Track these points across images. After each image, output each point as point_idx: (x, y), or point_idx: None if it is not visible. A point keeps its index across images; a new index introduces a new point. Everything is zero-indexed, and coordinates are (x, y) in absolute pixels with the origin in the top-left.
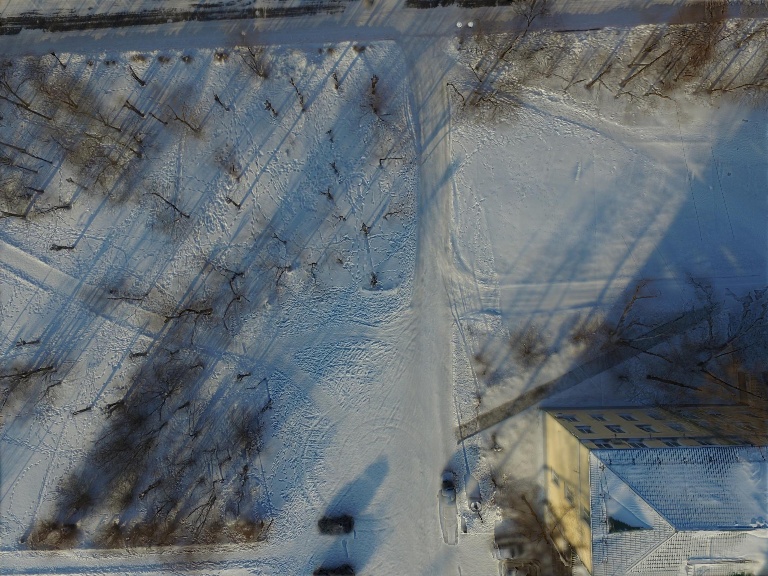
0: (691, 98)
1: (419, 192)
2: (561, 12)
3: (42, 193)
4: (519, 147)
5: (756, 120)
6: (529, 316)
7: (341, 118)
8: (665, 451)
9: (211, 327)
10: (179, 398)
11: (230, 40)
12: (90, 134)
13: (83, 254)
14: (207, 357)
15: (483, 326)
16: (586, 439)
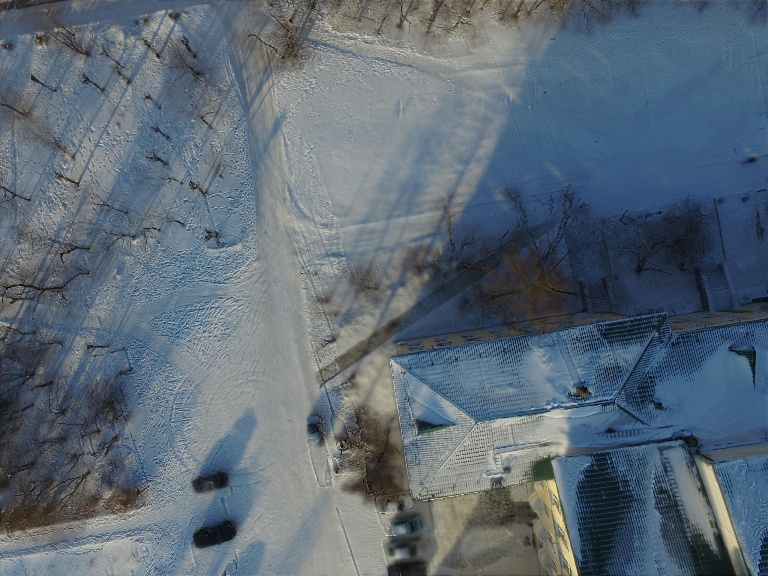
0: (499, 24)
1: (251, 148)
2: None
3: None
4: (341, 92)
5: (563, 37)
6: (373, 254)
7: (166, 85)
8: (461, 349)
9: (65, 305)
10: (42, 379)
11: (50, 23)
12: None
13: None
14: (64, 335)
15: (330, 269)
16: None
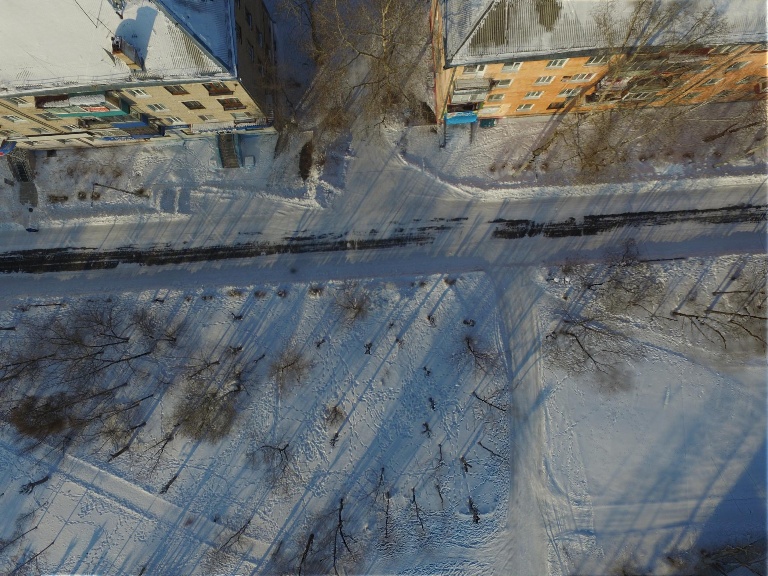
0: None
1: (512, 417)
2: (645, 240)
3: (144, 425)
4: (609, 373)
5: None
6: (622, 535)
7: (434, 347)
8: None
9: (313, 552)
10: None
11: (323, 272)
12: (189, 366)
13: (186, 483)
14: None
15: (578, 546)
16: None
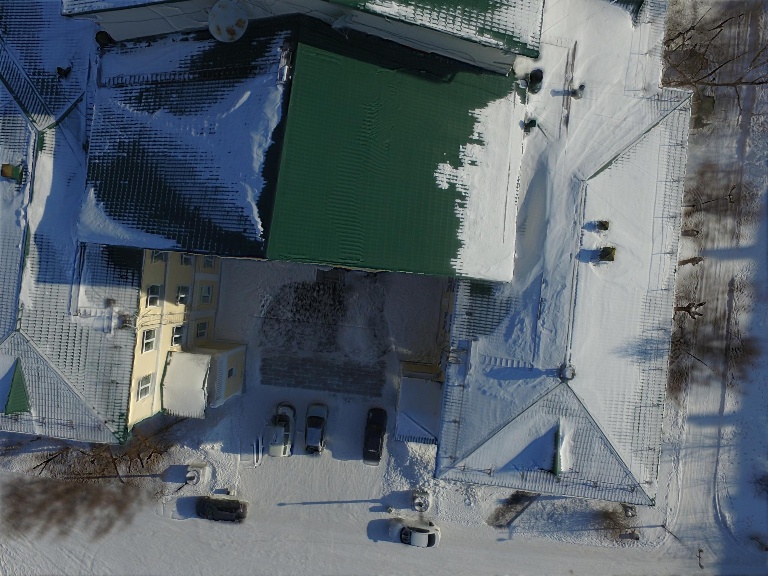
0: None
1: None
2: None
3: None
4: None
5: None
6: None
7: None
8: None
9: None
10: None
11: None
12: None
13: None
14: None
15: None
16: None
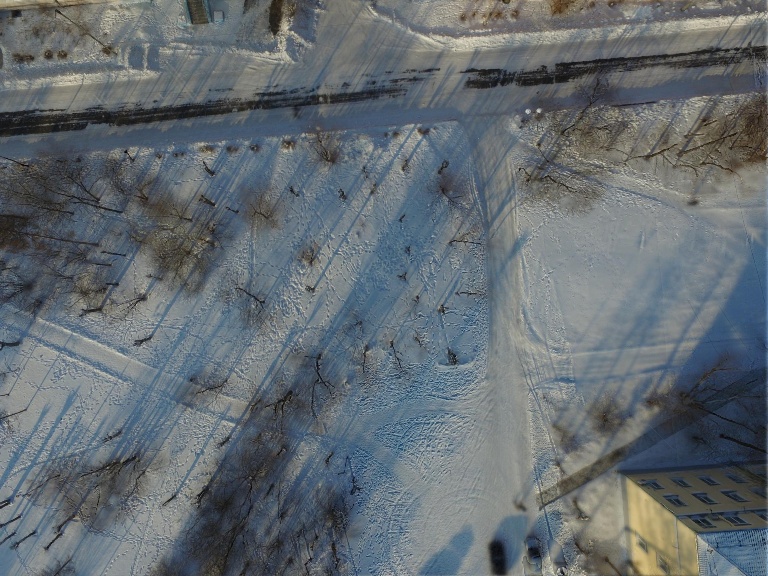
0: (746, 165)
1: (489, 267)
2: (617, 86)
3: (117, 286)
4: (584, 219)
5: None
6: (602, 382)
7: (409, 198)
8: None
9: (292, 409)
10: (263, 481)
11: (296, 127)
12: (162, 225)
13: (161, 344)
14: (289, 439)
15: (558, 394)
16: (683, 515)
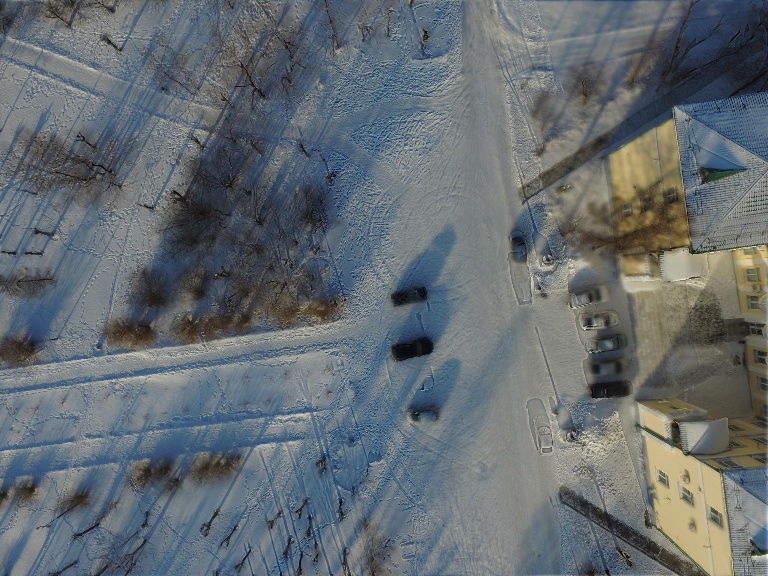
0: None
1: None
2: None
3: None
4: None
5: None
6: (581, 69)
7: None
8: (749, 97)
9: (265, 114)
10: (240, 188)
11: None
12: None
13: (131, 56)
14: (264, 144)
15: (536, 84)
16: None
